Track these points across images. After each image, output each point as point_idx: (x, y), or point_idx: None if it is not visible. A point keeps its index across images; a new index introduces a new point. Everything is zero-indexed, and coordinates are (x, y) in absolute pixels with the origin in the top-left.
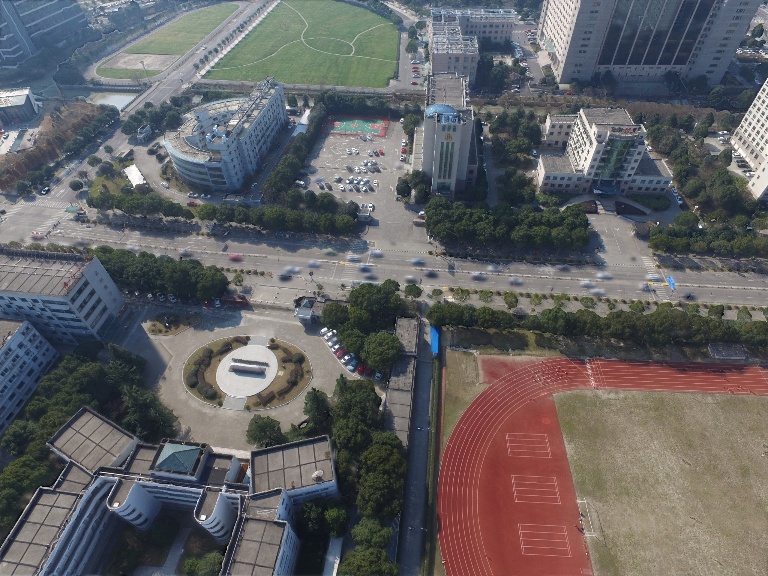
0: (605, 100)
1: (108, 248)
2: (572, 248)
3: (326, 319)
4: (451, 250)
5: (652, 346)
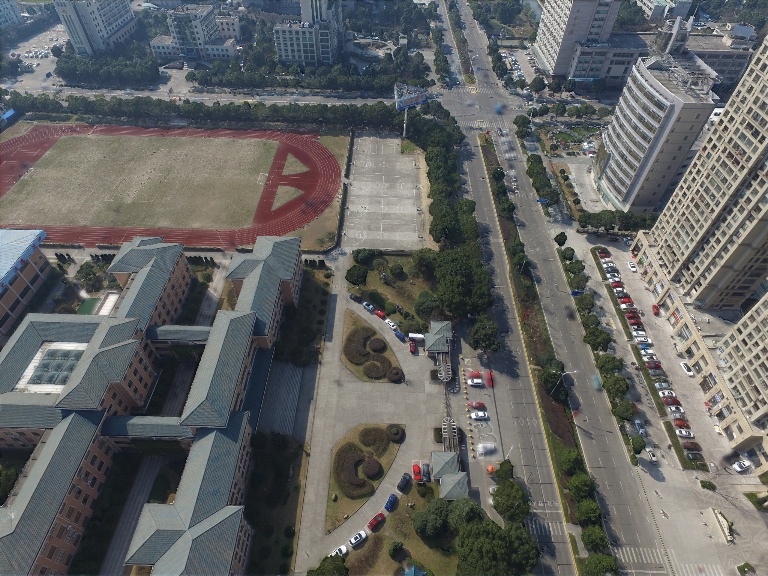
0: None
1: None
2: (144, 83)
3: None
4: (69, 84)
5: (142, 121)
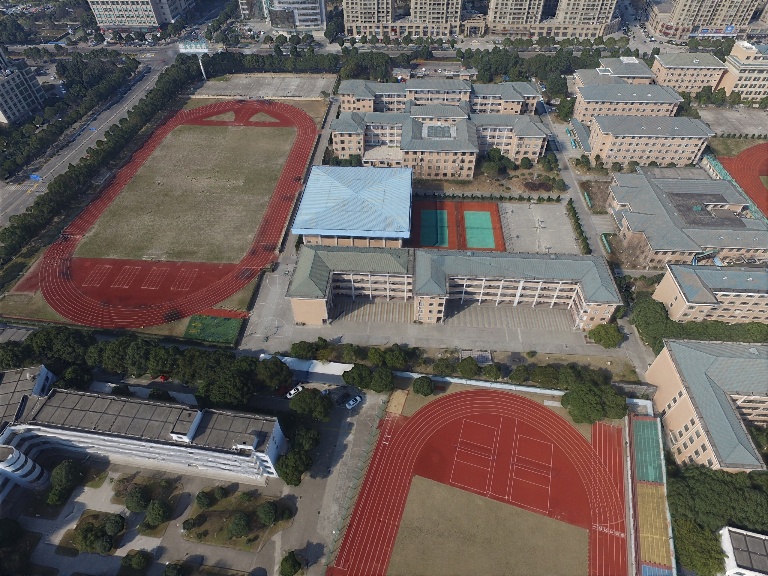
0: None
1: None
2: None
3: None
4: None
5: (75, 205)
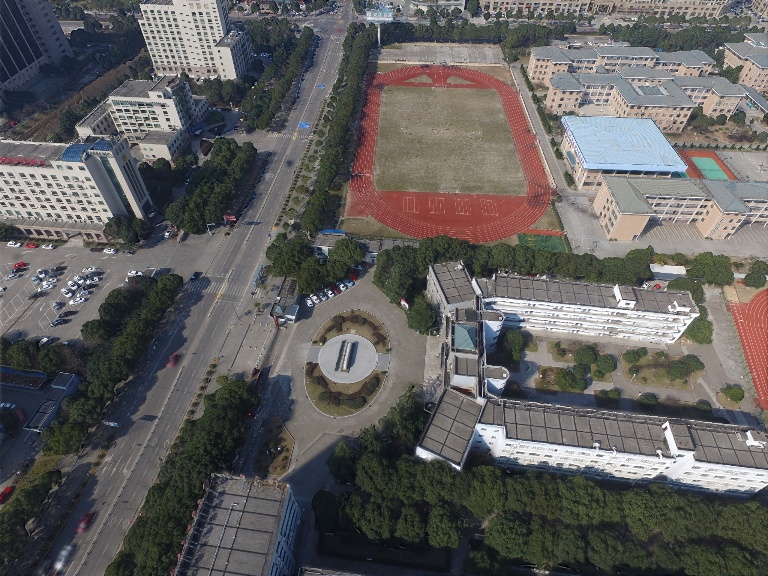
0: (49, 108)
1: (119, 559)
2: None
3: (311, 285)
4: (228, 222)
5: None
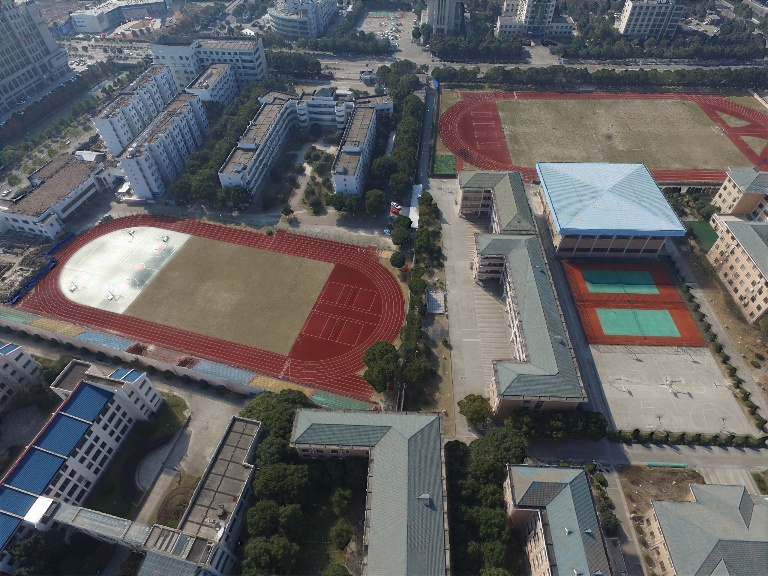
0: None
1: None
2: (513, 57)
3: (379, 73)
4: (445, 60)
5: (549, 87)
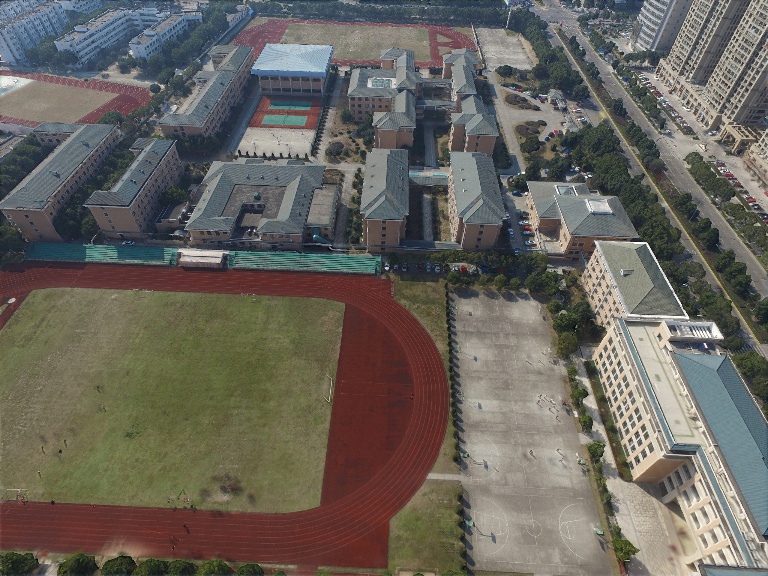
0: None
1: None
2: (323, 1)
3: None
4: None
5: (334, 18)
